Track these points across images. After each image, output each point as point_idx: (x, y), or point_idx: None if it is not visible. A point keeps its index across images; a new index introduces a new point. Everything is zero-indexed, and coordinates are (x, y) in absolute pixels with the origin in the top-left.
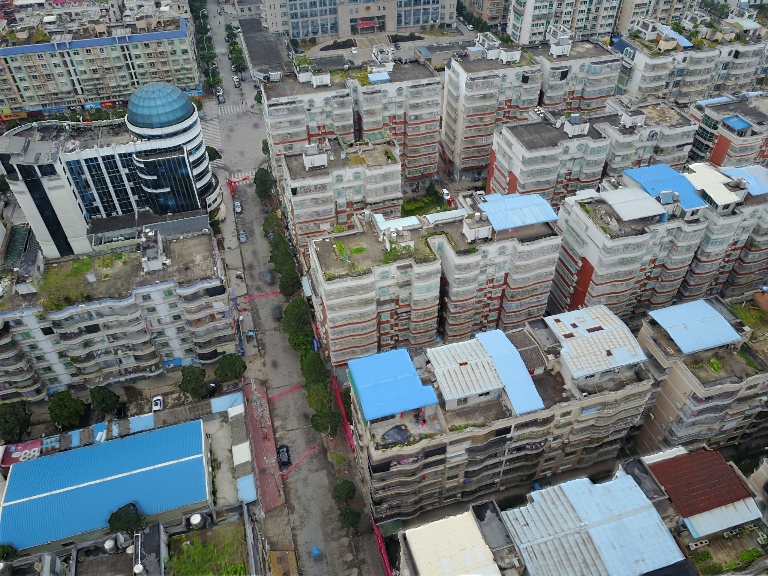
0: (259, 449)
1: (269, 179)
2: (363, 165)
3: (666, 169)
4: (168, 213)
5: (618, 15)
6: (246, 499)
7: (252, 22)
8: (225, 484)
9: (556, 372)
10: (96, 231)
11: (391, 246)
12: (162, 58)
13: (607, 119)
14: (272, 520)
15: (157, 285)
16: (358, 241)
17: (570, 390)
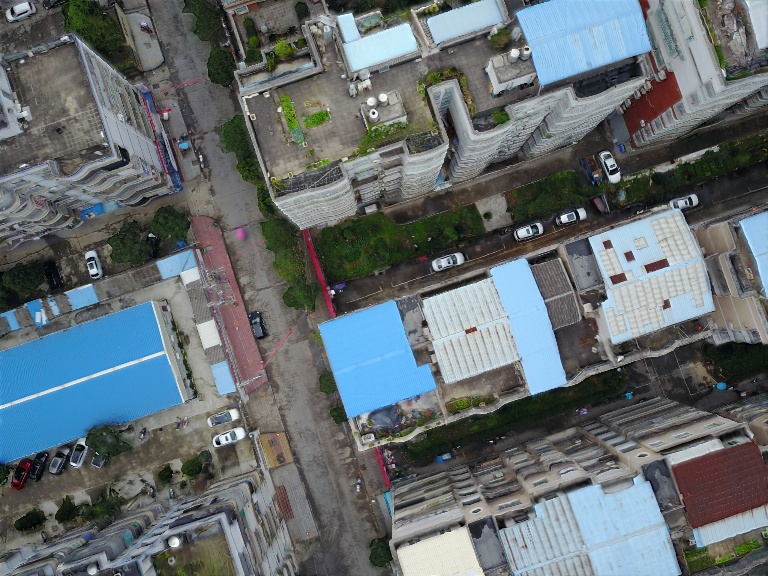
0: (228, 317)
1: None
2: None
3: None
4: None
5: None
6: (225, 389)
7: None
8: (199, 363)
9: (590, 318)
10: None
11: (370, 130)
12: None
13: None
14: (257, 402)
15: (25, 170)
16: (316, 94)
17: (603, 345)
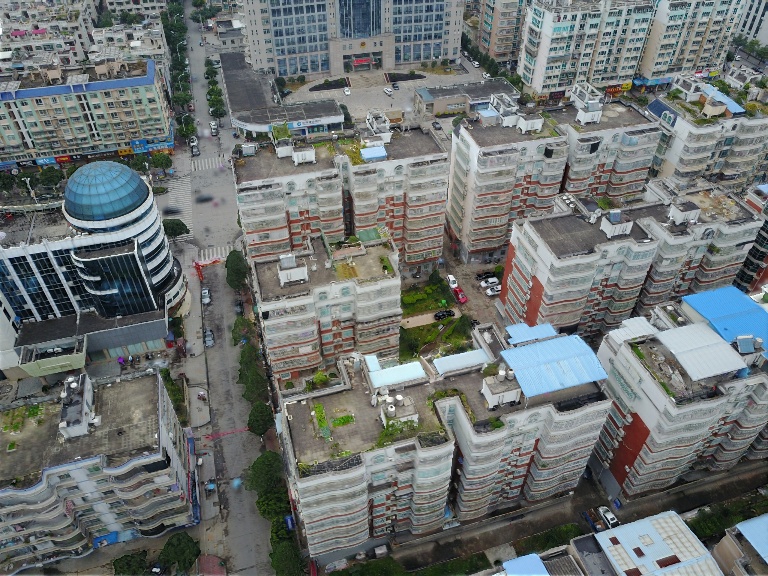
0: None
1: (242, 267)
2: (353, 280)
3: (738, 296)
4: (117, 316)
5: (641, 55)
6: None
7: (234, 57)
8: None
9: None
10: (26, 341)
11: (388, 423)
12: (125, 108)
13: (651, 211)
14: None
15: (77, 462)
16: (344, 404)
17: None
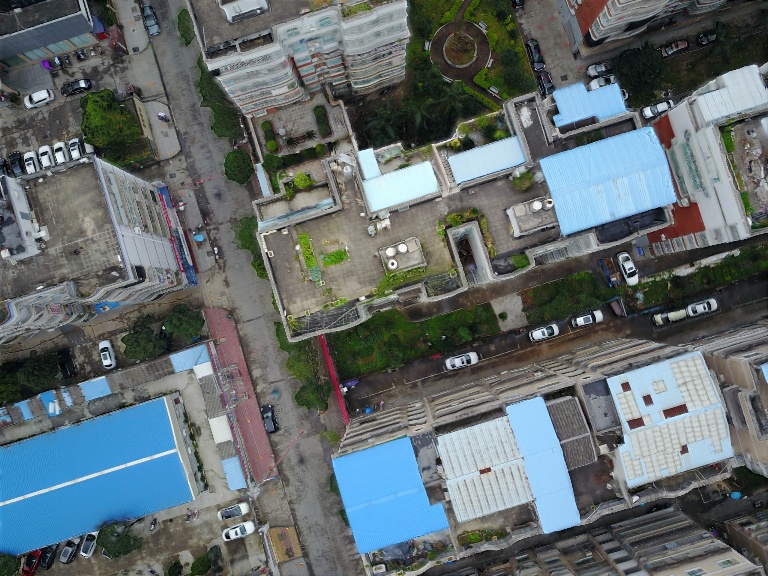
0: (240, 410)
1: None
2: (334, 8)
3: None
4: (14, 9)
5: None
6: (236, 485)
7: None
8: (210, 455)
9: (606, 455)
10: None
11: (388, 276)
12: None
13: None
14: (267, 496)
15: (42, 291)
16: (335, 232)
17: (618, 483)
